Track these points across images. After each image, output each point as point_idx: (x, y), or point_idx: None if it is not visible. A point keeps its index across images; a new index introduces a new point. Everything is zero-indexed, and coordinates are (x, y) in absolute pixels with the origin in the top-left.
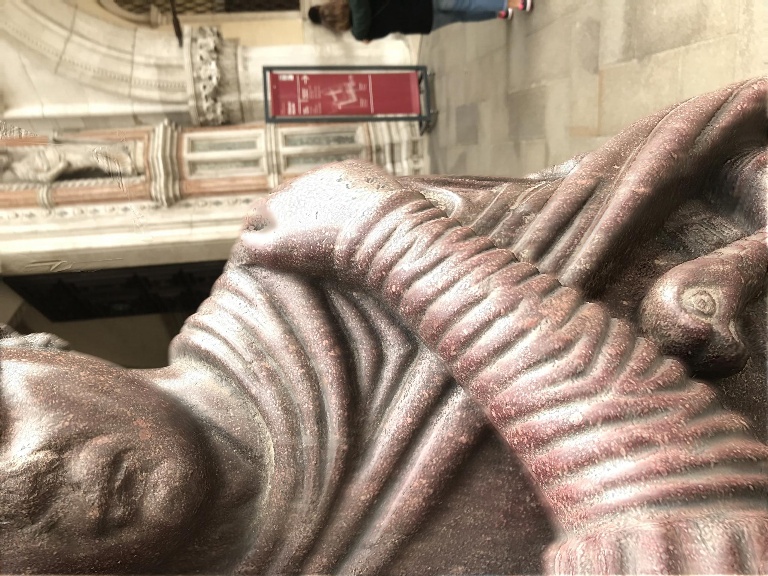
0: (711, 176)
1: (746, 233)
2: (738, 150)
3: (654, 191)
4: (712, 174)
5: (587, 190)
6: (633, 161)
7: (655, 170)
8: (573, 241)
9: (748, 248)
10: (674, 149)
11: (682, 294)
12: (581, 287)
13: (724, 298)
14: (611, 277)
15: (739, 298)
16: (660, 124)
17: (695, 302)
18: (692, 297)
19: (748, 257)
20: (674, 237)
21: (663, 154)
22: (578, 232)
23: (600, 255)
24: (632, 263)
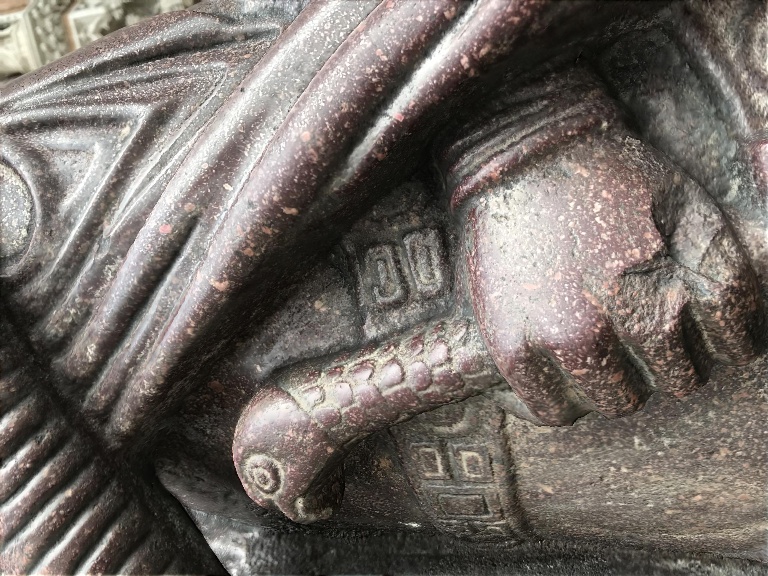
0: (435, 155)
1: (450, 285)
2: (503, 96)
3: (259, 268)
4: (435, 154)
5: (172, 247)
6: (231, 208)
7: (249, 246)
8: (144, 343)
9: (357, 402)
10: (288, 200)
11: (247, 458)
12: (155, 405)
13: (290, 479)
14: (242, 336)
15: (318, 472)
16: (293, 110)
17: (256, 475)
18: (254, 468)
19: (350, 418)
20: (350, 267)
21: (266, 214)
22: (151, 329)
23: (170, 375)
24: (282, 305)
